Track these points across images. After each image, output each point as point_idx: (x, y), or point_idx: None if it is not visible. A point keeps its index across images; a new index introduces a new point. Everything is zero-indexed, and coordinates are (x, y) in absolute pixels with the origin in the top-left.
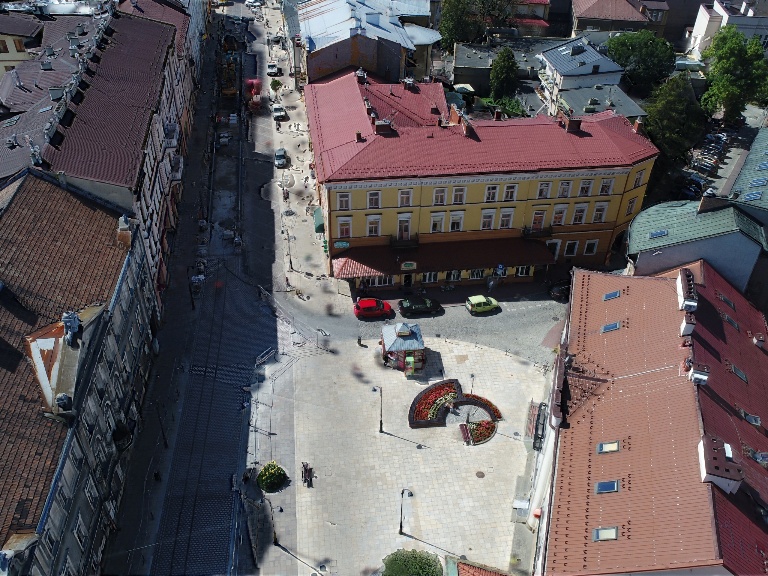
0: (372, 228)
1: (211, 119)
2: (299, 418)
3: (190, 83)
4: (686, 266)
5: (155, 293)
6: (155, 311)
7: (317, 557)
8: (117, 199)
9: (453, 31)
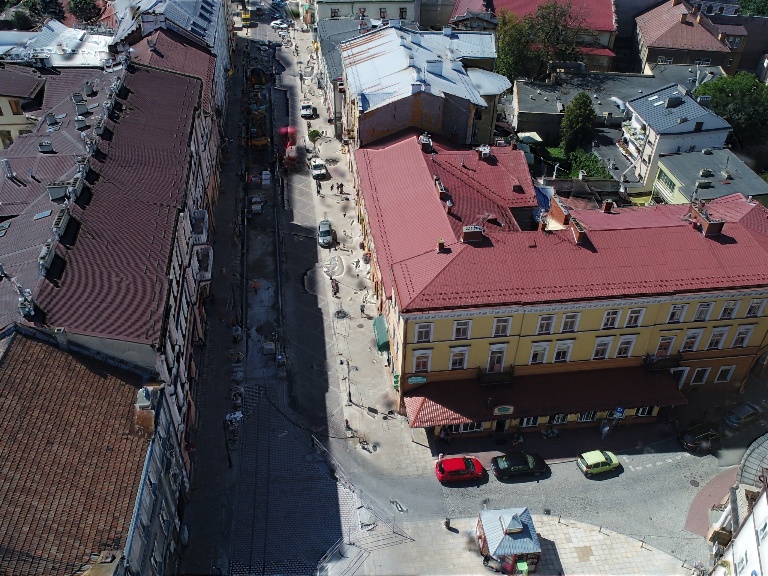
0: (456, 360)
1: (240, 178)
2: None
3: (216, 137)
4: None
5: (183, 459)
6: (183, 482)
7: None
8: (135, 358)
9: (512, 66)
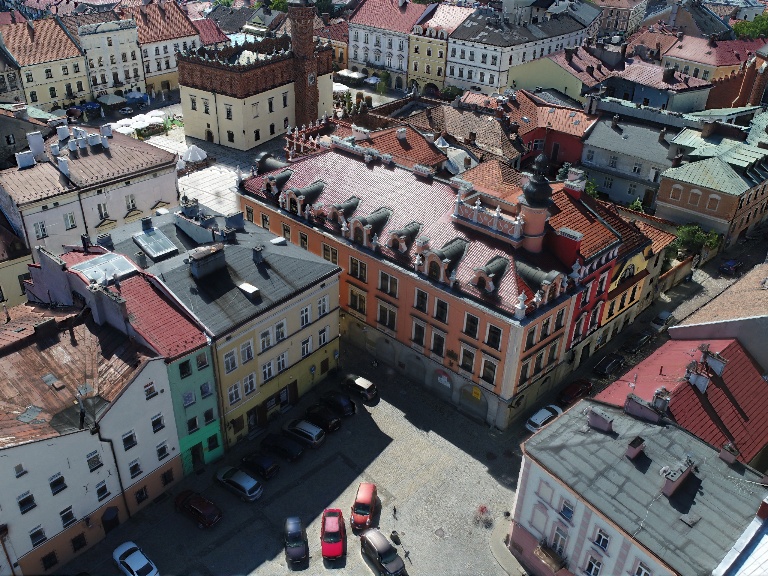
0: None
1: None
2: None
3: None
4: None
5: None
6: None
7: None
8: None
9: None
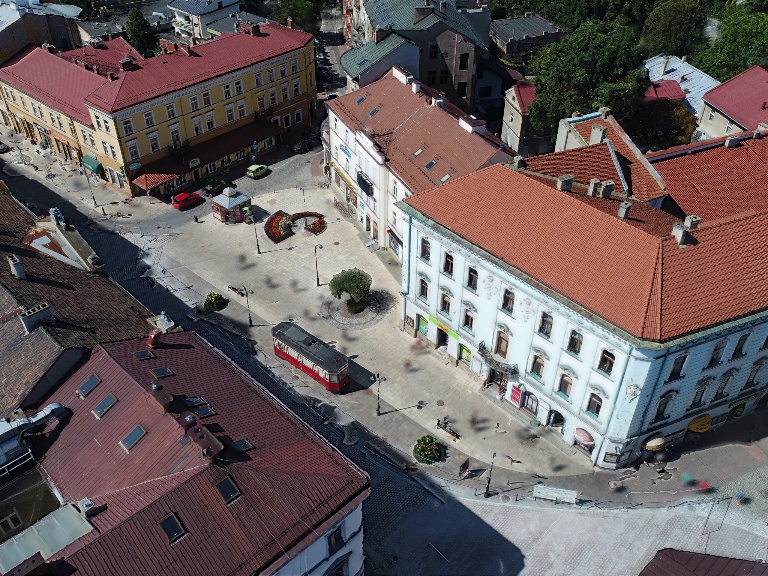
0: (153, 145)
1: None
2: (199, 272)
3: None
4: (387, 73)
5: None
6: None
7: (283, 318)
8: None
9: None
